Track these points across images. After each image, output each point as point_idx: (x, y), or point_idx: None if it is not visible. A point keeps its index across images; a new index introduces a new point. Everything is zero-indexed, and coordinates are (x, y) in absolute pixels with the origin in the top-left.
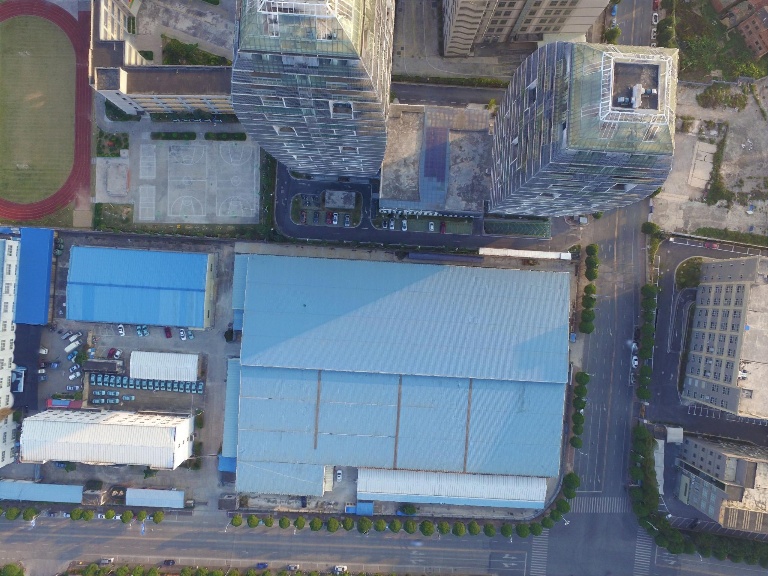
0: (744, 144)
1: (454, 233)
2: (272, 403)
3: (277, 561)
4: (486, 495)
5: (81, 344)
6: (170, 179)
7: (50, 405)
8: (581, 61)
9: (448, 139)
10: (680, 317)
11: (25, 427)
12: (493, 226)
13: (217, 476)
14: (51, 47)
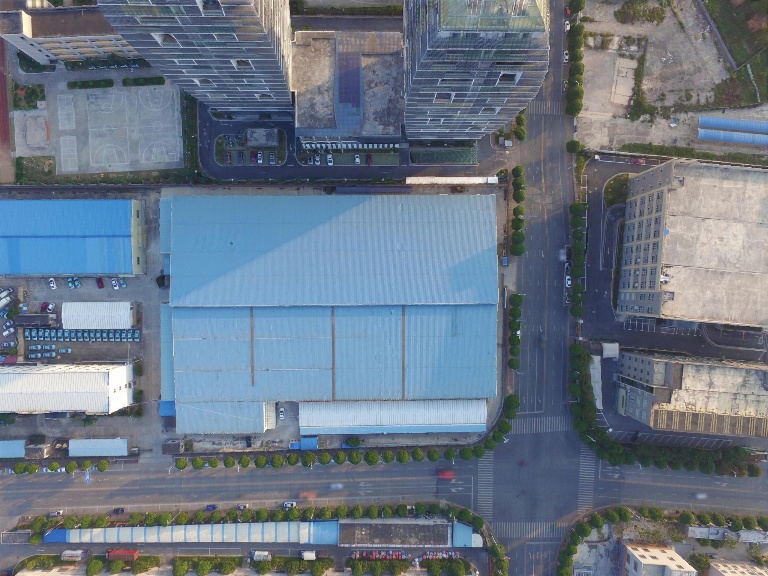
0: (664, 58)
1: (381, 165)
2: (206, 343)
3: (226, 502)
4: (428, 421)
5: (12, 300)
6: (90, 128)
7: None
8: None
9: (361, 64)
10: (611, 235)
11: None
12: (420, 156)
13: (160, 422)
14: None
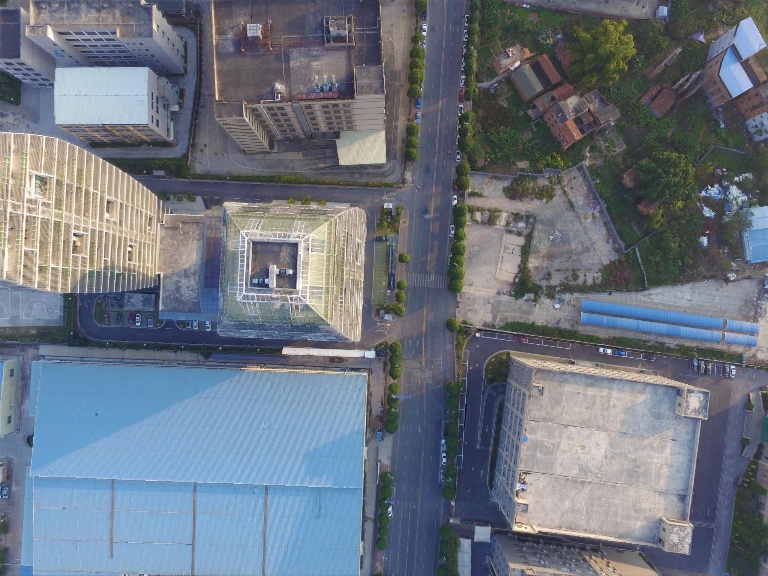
0: (552, 236)
1: None
2: (66, 513)
3: None
4: None
5: None
6: None
7: None
8: (229, 235)
9: None
10: (491, 411)
11: None
12: None
13: None
14: None
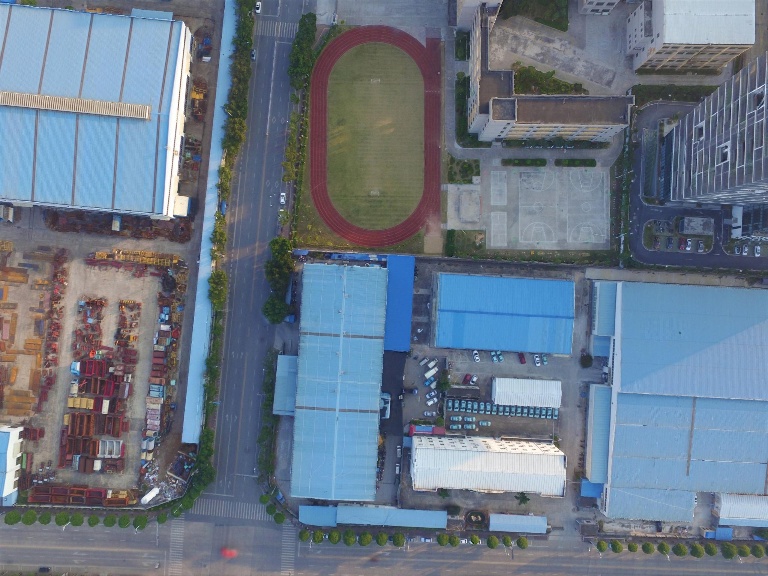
0: None
1: None
2: (646, 430)
3: None
4: None
5: (438, 370)
6: (521, 205)
7: (414, 431)
8: None
9: None
10: None
11: (418, 455)
12: None
13: (572, 501)
14: (400, 74)
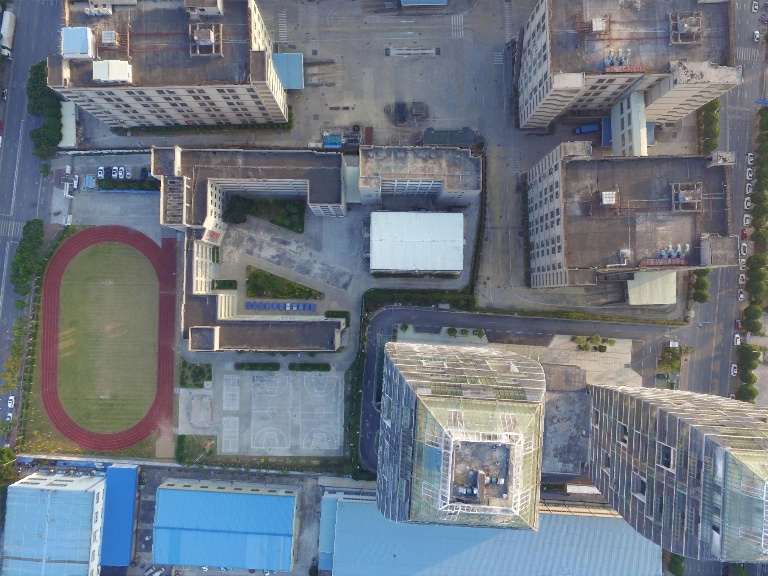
0: None
1: None
2: None
3: None
4: None
5: None
6: (254, 410)
7: None
8: (738, 477)
9: None
10: None
11: None
12: None
13: None
14: (134, 275)
